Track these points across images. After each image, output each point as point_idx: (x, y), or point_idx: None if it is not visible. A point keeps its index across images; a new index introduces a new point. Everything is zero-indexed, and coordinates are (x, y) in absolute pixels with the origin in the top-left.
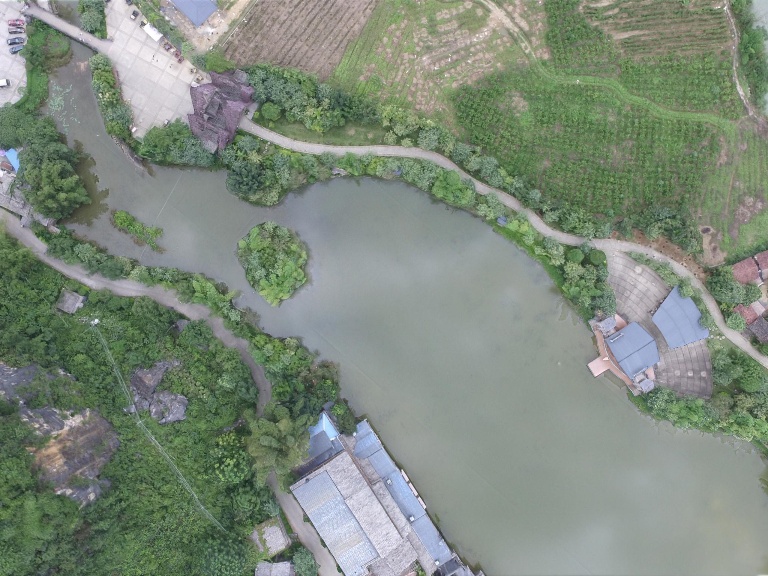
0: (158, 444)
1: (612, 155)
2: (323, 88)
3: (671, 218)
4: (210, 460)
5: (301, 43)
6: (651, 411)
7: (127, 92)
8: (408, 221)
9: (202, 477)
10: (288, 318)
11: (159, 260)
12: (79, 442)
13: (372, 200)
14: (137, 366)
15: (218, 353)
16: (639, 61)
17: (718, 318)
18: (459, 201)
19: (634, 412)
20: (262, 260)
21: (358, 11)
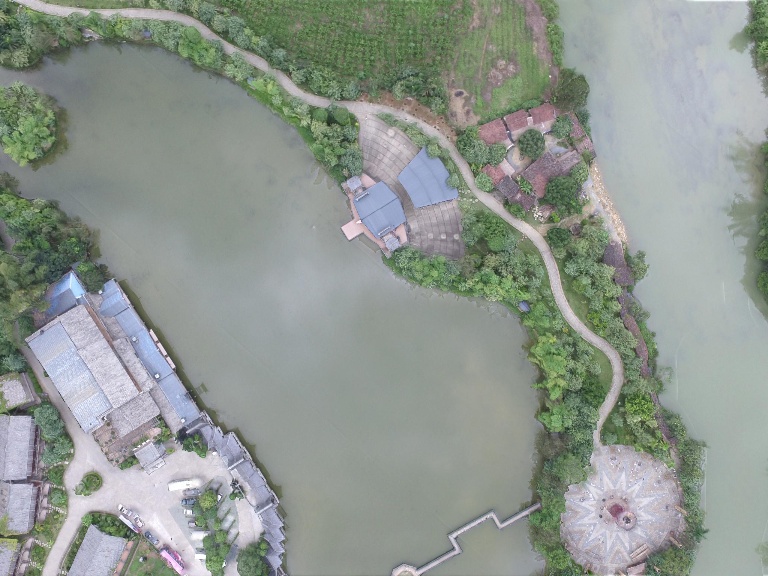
0: None
1: (364, 18)
2: None
3: (414, 76)
4: None
5: None
6: (401, 272)
7: None
8: (163, 85)
9: None
10: (43, 182)
11: None
12: None
13: (129, 65)
14: None
15: None
16: None
17: (471, 181)
18: (204, 60)
19: (389, 276)
20: (5, 117)
21: None
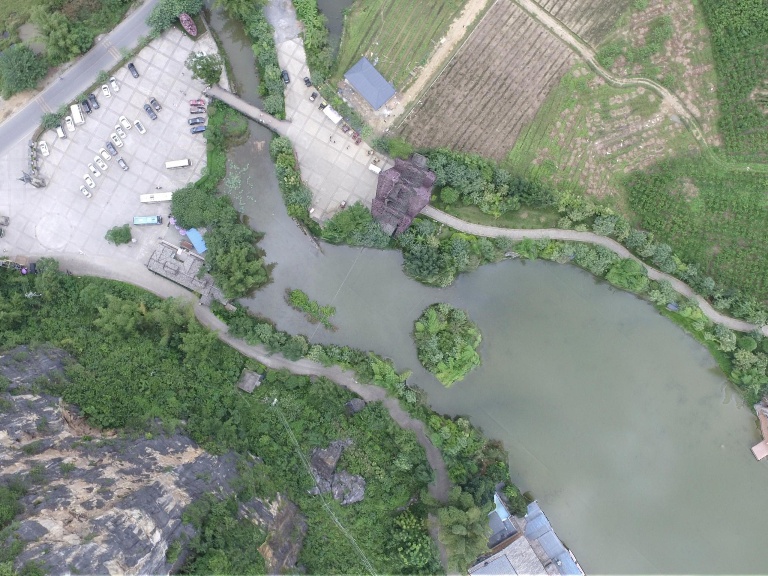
0: (341, 526)
1: None
2: (502, 174)
3: None
4: (392, 543)
5: (475, 126)
6: None
7: (304, 173)
8: (576, 303)
9: (382, 559)
10: (456, 397)
11: (331, 338)
12: (280, 531)
13: (540, 281)
14: (314, 445)
15: (397, 435)
16: None
17: None
18: (634, 288)
19: None
20: (440, 343)
21: (532, 95)
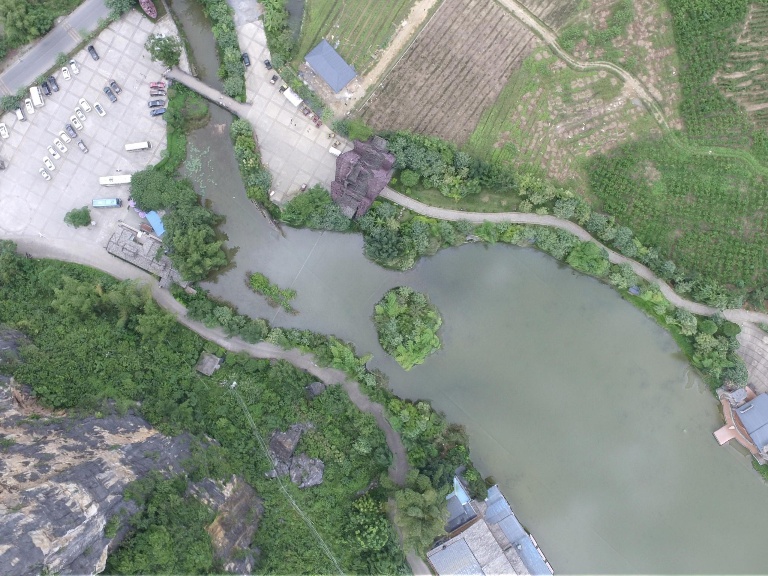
0: (298, 509)
1: (743, 226)
2: (462, 157)
3: None
4: (350, 526)
5: (437, 109)
6: None
7: (265, 155)
8: (538, 287)
9: (340, 542)
10: (418, 381)
11: (292, 322)
12: (233, 512)
13: (502, 265)
14: (273, 429)
15: (356, 418)
16: None
17: None
18: (594, 271)
19: (758, 480)
20: (399, 326)
21: (494, 78)
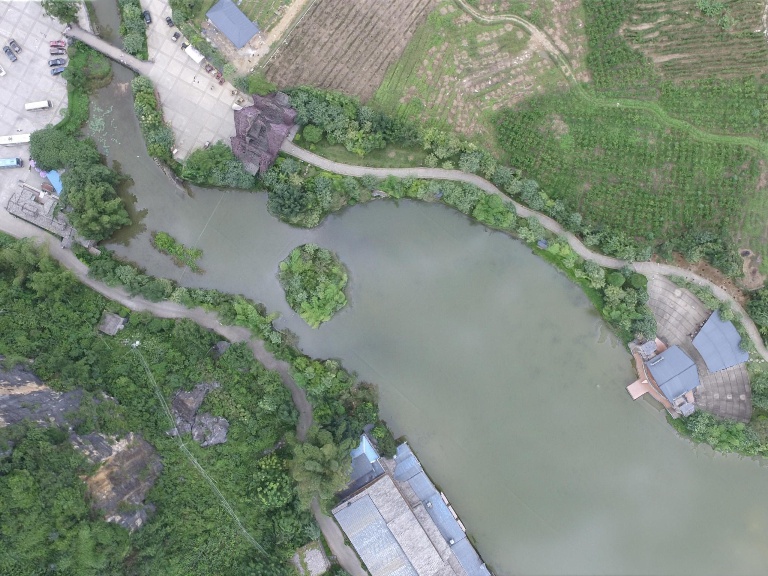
0: (200, 467)
1: (652, 178)
2: (365, 111)
3: (712, 242)
4: (252, 483)
5: (342, 65)
6: (690, 434)
7: (168, 114)
8: (447, 243)
9: (244, 500)
10: (327, 340)
11: (199, 281)
12: (125, 467)
13: (411, 222)
14: (178, 388)
15: (260, 376)
16: (679, 84)
17: (757, 341)
18: (500, 224)
19: (673, 435)
20: (303, 283)
21: (399, 33)
